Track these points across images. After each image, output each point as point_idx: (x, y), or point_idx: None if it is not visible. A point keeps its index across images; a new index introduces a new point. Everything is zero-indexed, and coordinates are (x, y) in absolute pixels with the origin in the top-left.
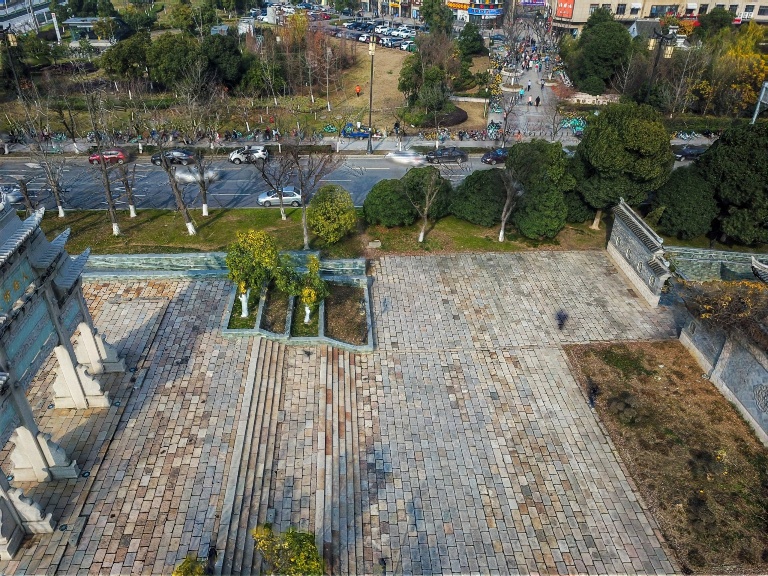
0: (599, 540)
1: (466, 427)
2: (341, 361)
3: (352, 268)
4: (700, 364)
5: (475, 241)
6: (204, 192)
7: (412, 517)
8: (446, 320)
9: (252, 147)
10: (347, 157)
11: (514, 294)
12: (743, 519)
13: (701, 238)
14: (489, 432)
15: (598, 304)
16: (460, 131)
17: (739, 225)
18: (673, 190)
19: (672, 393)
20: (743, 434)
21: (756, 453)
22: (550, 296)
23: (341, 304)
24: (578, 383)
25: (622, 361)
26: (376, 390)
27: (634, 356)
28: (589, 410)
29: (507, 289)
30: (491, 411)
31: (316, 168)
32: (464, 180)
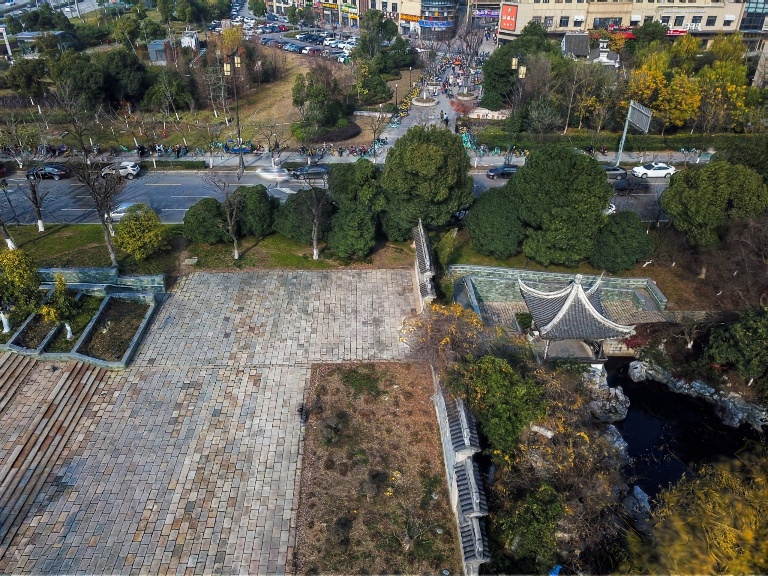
0: (230, 556)
1: (170, 443)
2: (86, 376)
3: (151, 285)
4: (434, 385)
5: (290, 259)
6: (37, 209)
7: (67, 529)
8: (215, 337)
9: (122, 163)
10: (218, 173)
11: (297, 312)
12: (378, 539)
13: (520, 258)
14: (189, 448)
15: (373, 323)
16: (340, 147)
17: (534, 246)
18: (480, 211)
19: (388, 414)
20: (433, 456)
21: (434, 475)
22: (331, 315)
23: (117, 320)
24: (304, 402)
25: (359, 381)
26: (107, 405)
27: (375, 376)
28: (299, 429)
29: (293, 307)
30: (204, 428)
31: (112, 189)
32: (286, 199)
